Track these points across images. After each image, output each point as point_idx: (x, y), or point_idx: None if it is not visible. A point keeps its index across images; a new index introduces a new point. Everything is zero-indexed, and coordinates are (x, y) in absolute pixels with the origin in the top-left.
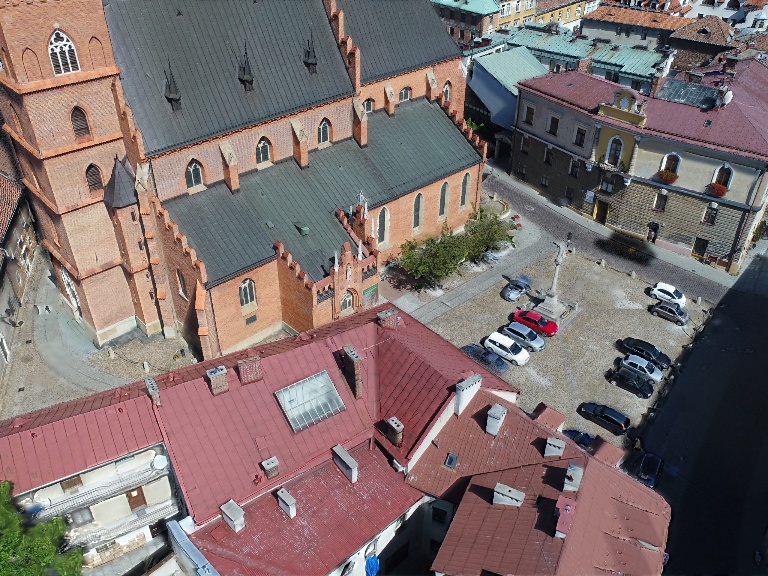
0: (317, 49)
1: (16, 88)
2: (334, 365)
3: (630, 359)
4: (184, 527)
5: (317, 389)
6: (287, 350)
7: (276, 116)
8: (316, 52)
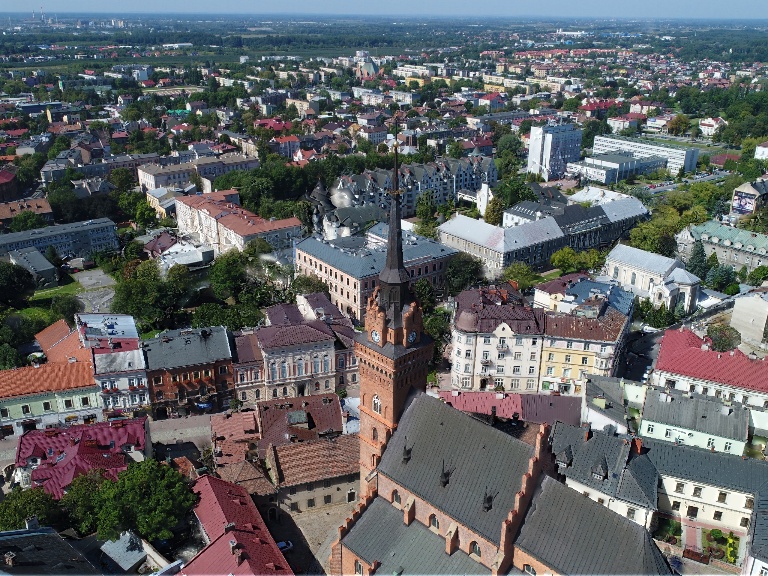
0: (500, 502)
1: None
2: None
3: None
4: (181, 566)
5: None
6: (253, 570)
7: (442, 510)
8: (498, 502)
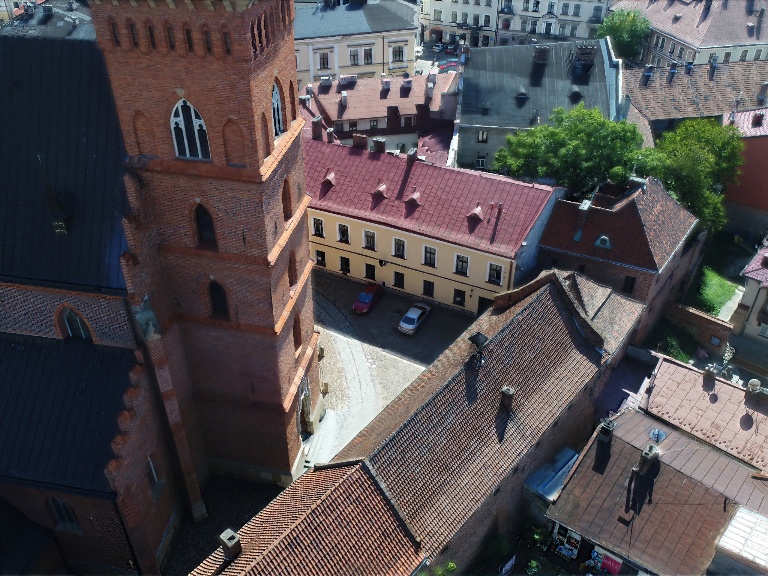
0: None
1: None
2: None
3: None
4: None
5: None
6: (330, 145)
7: None
8: None
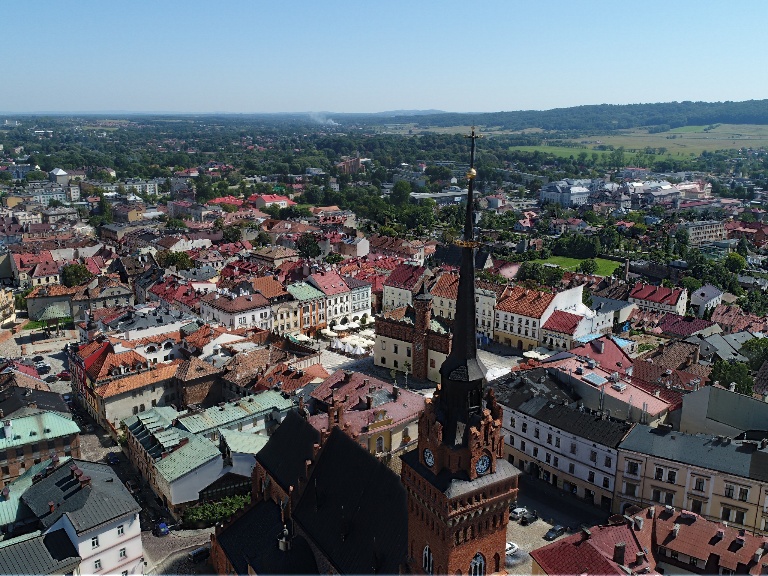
0: None
1: (503, 574)
2: (613, 562)
3: (519, 512)
4: None
5: (629, 571)
6: (614, 570)
7: None
8: None
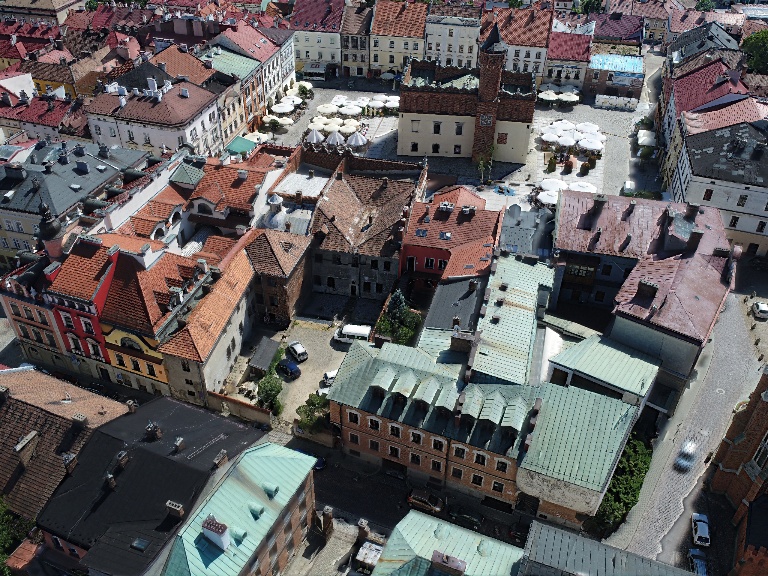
0: None
1: None
2: None
3: None
4: None
5: None
6: None
7: None
8: None
